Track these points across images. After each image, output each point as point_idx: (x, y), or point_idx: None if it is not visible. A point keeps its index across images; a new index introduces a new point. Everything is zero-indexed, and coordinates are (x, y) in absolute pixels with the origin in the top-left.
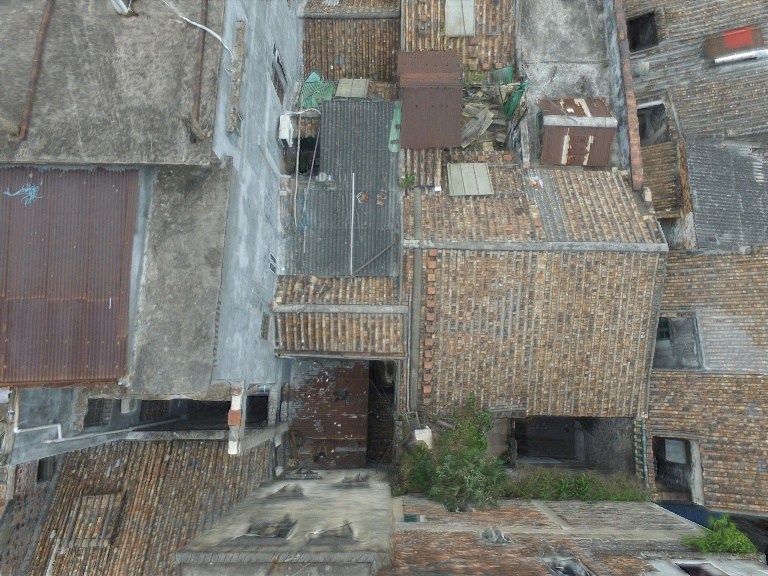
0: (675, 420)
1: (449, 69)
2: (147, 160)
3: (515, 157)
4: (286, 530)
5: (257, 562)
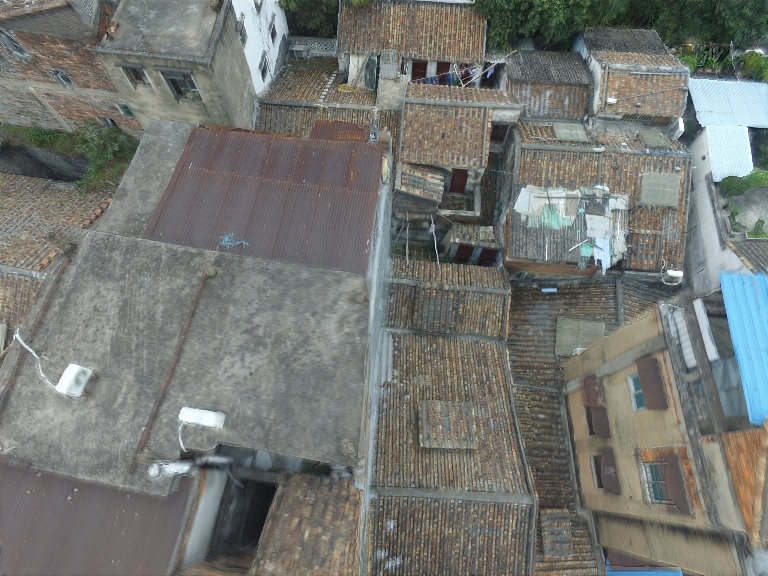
0: None
1: None
2: (116, 237)
3: None
4: (179, 94)
5: (161, 53)
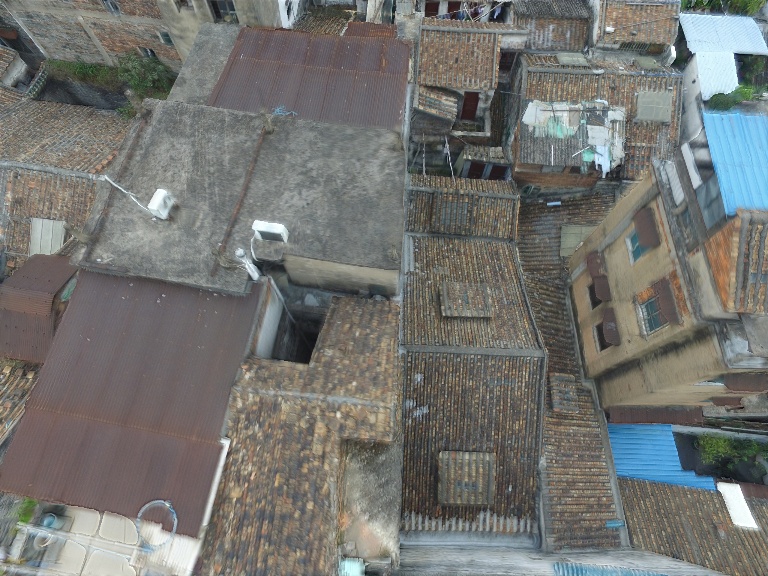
0: (7, 94)
1: (5, 317)
2: (184, 105)
3: (5, 266)
4: (218, 17)
5: None
